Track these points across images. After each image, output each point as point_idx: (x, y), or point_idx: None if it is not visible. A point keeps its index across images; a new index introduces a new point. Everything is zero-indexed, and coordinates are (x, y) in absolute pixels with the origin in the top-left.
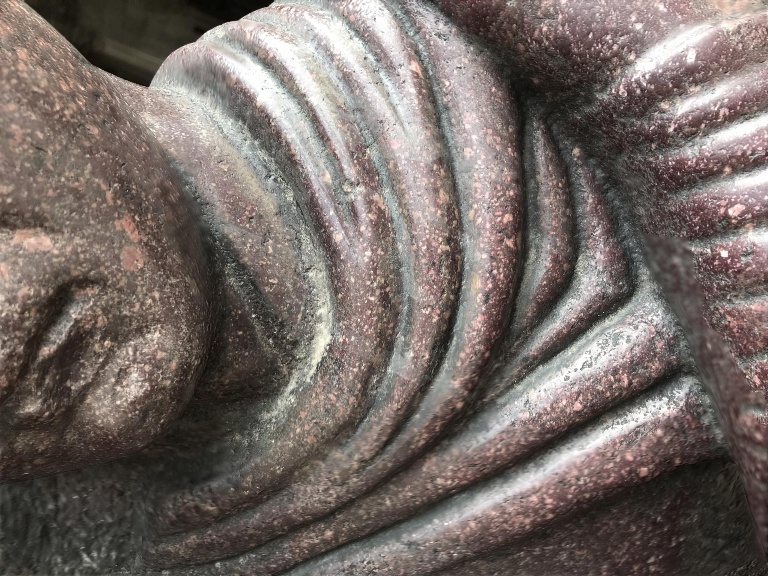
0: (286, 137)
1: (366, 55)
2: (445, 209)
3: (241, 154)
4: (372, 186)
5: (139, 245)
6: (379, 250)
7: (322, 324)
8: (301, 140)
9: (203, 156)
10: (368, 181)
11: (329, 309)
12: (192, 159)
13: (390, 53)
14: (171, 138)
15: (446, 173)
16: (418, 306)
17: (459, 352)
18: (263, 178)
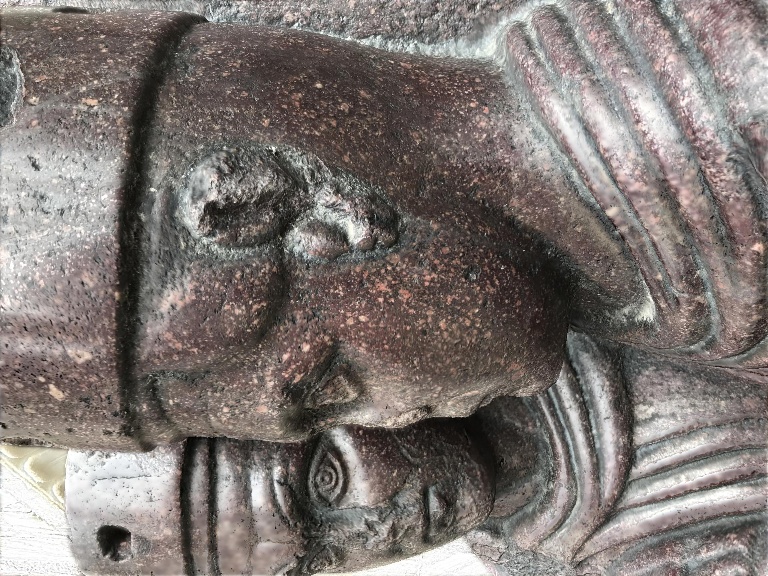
0: (628, 243)
1: (714, 214)
2: (756, 322)
3: (593, 214)
4: (696, 293)
5: (521, 369)
6: (693, 320)
7: (650, 303)
8: (640, 250)
9: (561, 225)
10: (692, 291)
11: (654, 308)
12: (552, 231)
13: (735, 232)
14: (535, 218)
15: (765, 306)
16: (719, 343)
17: (747, 360)
18: (611, 231)
